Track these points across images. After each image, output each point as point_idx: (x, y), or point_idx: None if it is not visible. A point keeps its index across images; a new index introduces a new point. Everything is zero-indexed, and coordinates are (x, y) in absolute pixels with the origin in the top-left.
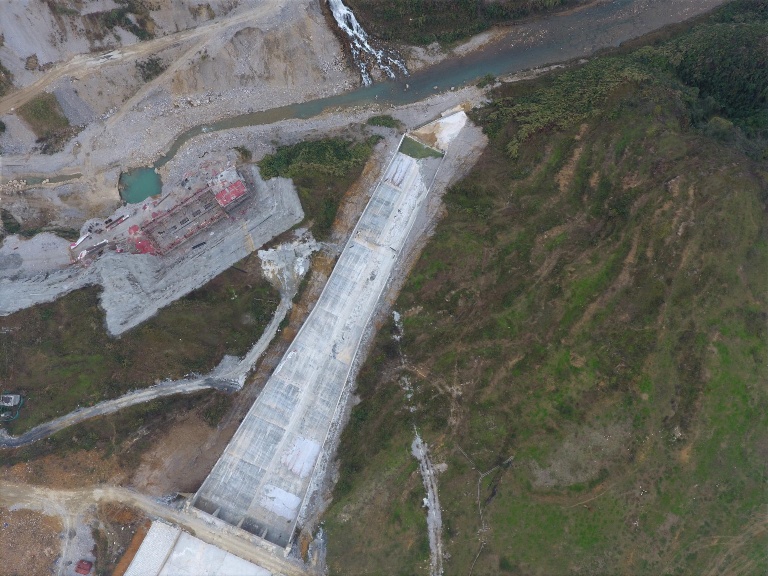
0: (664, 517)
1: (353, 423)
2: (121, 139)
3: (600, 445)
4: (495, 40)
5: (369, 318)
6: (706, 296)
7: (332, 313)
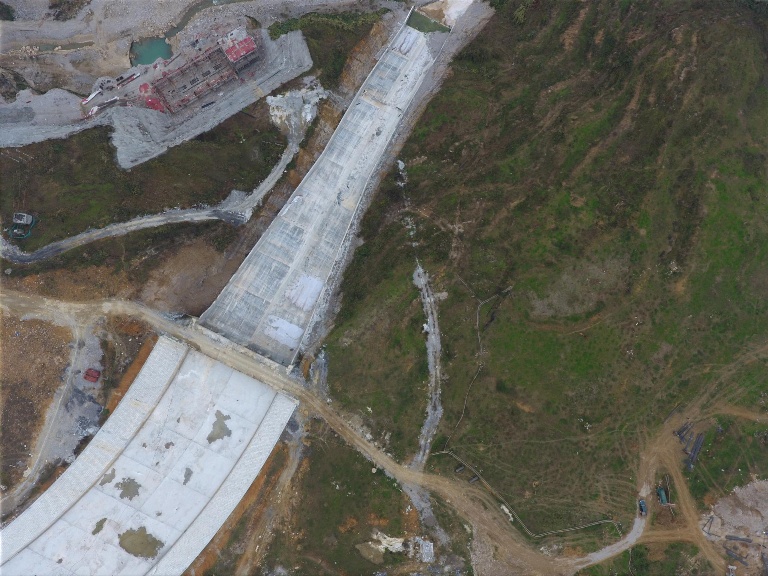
0: (658, 346)
1: (356, 260)
2: (133, 8)
3: (597, 278)
4: None
5: (374, 168)
6: (706, 137)
7: (338, 163)
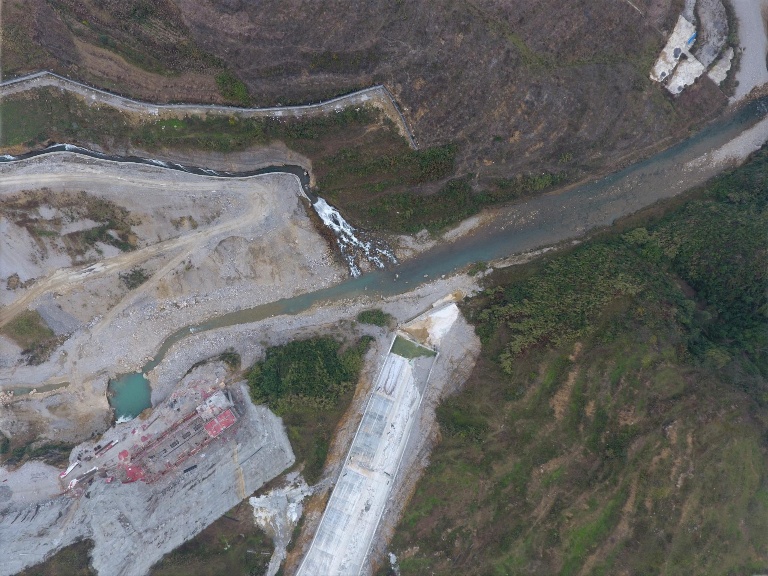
0: None
1: None
2: (108, 346)
3: None
4: (485, 224)
5: (365, 558)
6: (707, 555)
7: (327, 552)
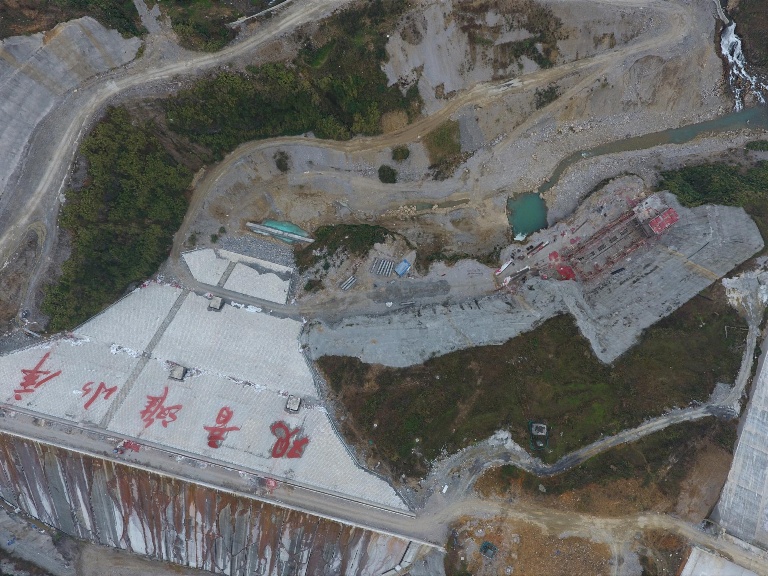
0: None
1: None
2: (508, 165)
3: None
4: None
5: None
6: None
7: None
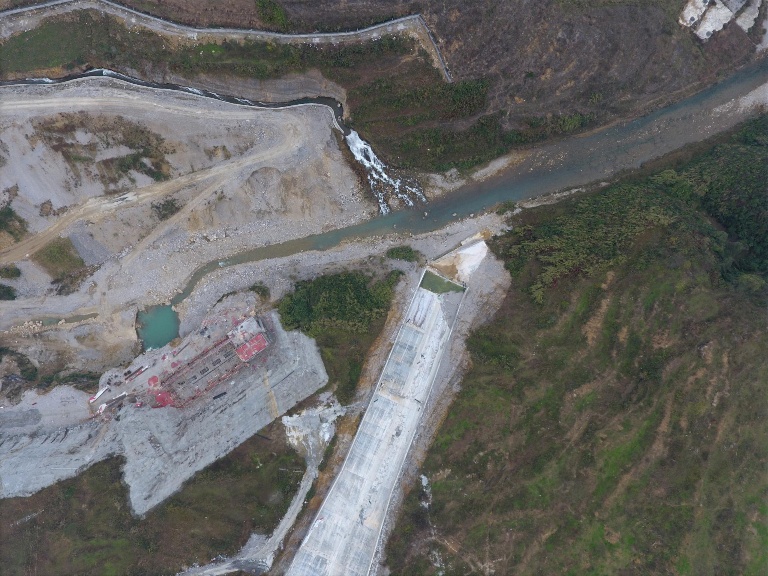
0: None
1: None
2: (137, 277)
3: None
4: (514, 164)
5: (396, 481)
6: (744, 472)
7: (358, 475)
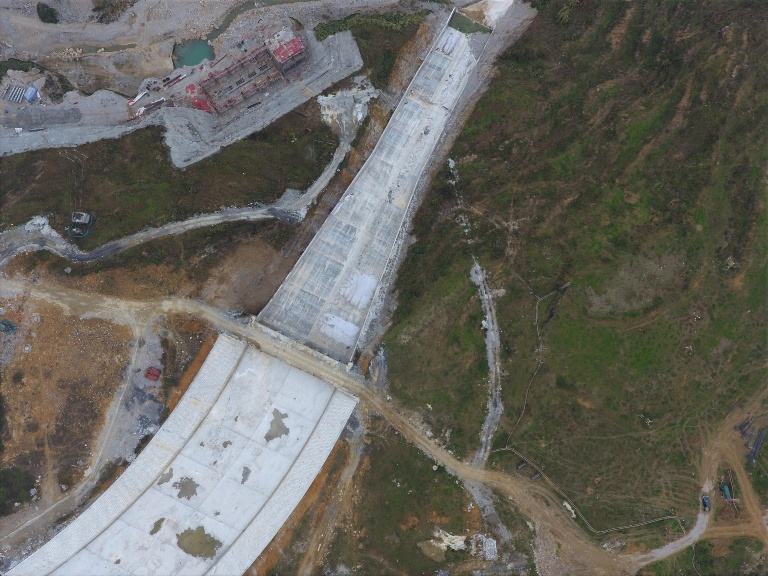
0: (717, 341)
1: (411, 257)
2: (176, 10)
3: (654, 274)
4: None
5: (424, 167)
6: (759, 133)
7: (387, 162)
